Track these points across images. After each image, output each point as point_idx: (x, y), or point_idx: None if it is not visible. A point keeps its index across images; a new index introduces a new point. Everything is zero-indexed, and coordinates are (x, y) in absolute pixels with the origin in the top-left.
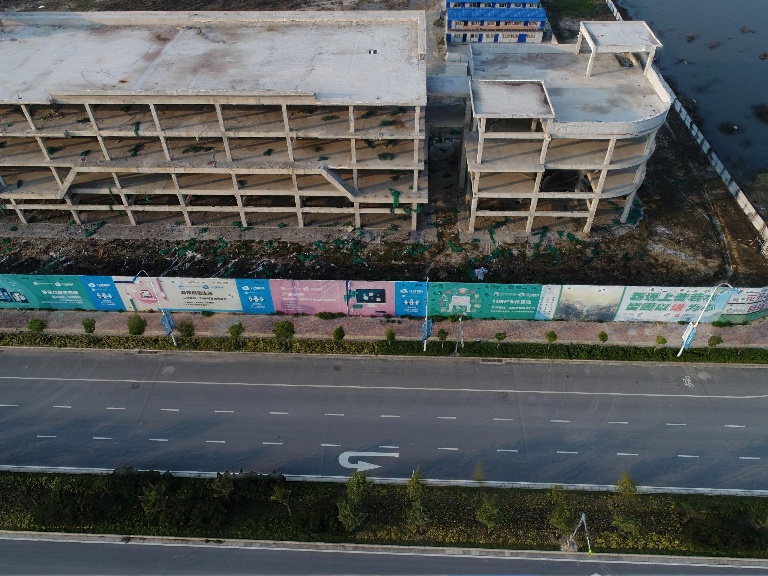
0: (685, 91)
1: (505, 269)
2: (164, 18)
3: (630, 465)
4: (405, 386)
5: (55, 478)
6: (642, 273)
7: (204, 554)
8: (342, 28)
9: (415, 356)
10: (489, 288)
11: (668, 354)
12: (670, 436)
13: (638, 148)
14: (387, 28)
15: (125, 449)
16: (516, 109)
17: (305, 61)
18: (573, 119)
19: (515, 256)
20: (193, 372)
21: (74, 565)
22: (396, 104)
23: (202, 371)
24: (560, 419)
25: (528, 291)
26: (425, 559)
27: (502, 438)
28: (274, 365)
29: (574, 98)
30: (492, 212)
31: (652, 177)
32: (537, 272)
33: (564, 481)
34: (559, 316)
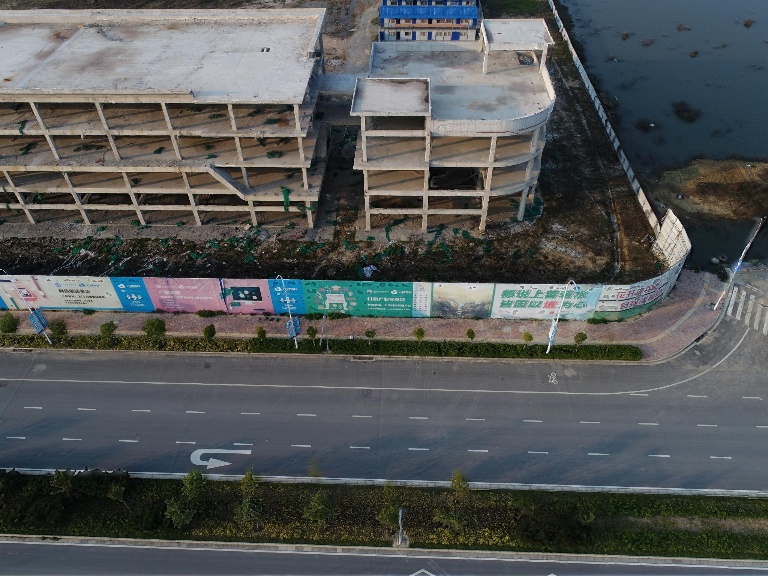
0: (609, 89)
1: (394, 267)
2: (66, 16)
3: (478, 461)
4: (271, 383)
5: None
6: (529, 270)
7: (38, 551)
8: (243, 26)
9: (287, 354)
10: (361, 286)
11: (537, 351)
12: (524, 433)
13: (526, 146)
14: (287, 26)
15: None
16: (395, 107)
17: (195, 59)
18: (457, 117)
19: (407, 254)
20: (64, 370)
21: None
22: (272, 102)
23: (73, 369)
24: (418, 416)
25: (400, 289)
26: (256, 555)
27: (357, 435)
28: (146, 363)
29: (464, 96)
30: (385, 210)
31: (559, 175)
32: (425, 270)
33: (410, 478)
34: (436, 313)
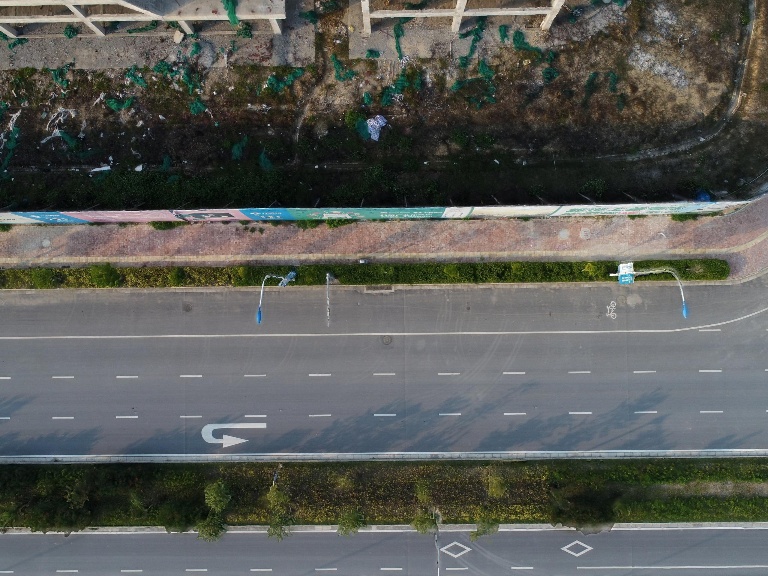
0: None
1: (411, 118)
2: None
3: (514, 427)
4: (271, 332)
5: None
6: (606, 119)
7: (82, 541)
8: None
9: None
10: (372, 211)
11: (599, 273)
12: (568, 388)
13: None
14: None
15: None
16: None
17: None
18: None
19: (429, 88)
20: (11, 322)
21: None
22: None
23: (22, 320)
24: (449, 371)
25: (426, 211)
26: (295, 536)
27: (381, 399)
28: (109, 307)
29: None
30: (395, 13)
31: None
32: (456, 123)
33: (441, 449)
34: (472, 217)
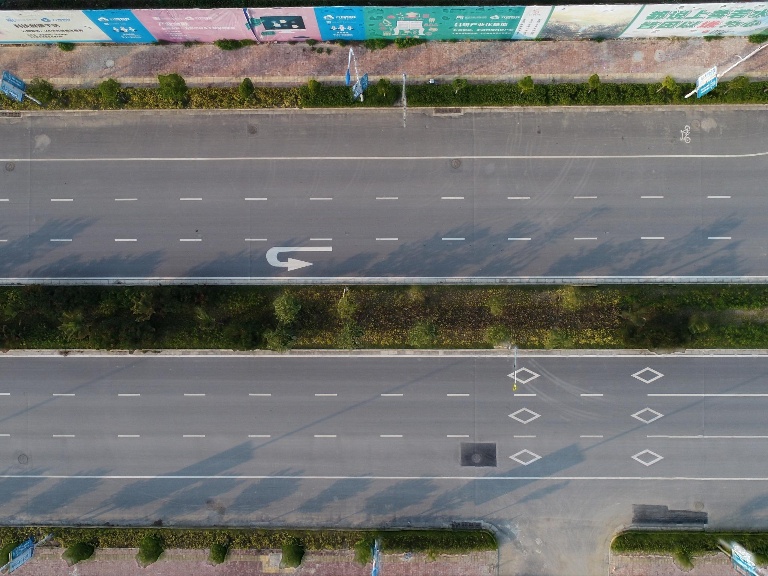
0: None
1: None
2: None
3: (585, 252)
4: (338, 155)
5: None
6: None
7: (145, 364)
8: None
9: (350, 108)
10: (449, 12)
11: (674, 95)
12: (640, 213)
13: None
14: None
15: (27, 253)
16: None
17: None
18: None
19: None
20: (74, 143)
21: (23, 379)
22: None
23: (85, 141)
24: (519, 195)
25: (504, 13)
26: (360, 360)
27: (449, 223)
28: (173, 128)
29: None
30: None
31: None
32: None
33: (510, 273)
34: (545, 35)
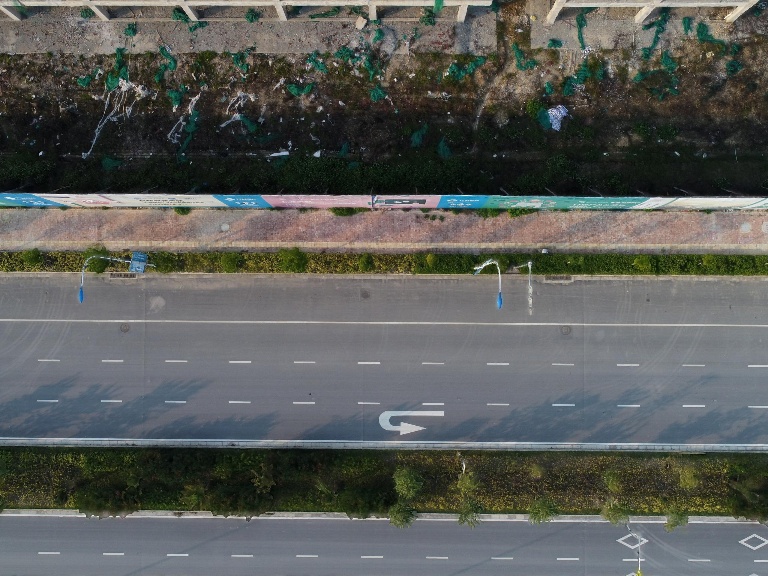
0: None
1: (593, 108)
2: None
3: (694, 420)
4: (450, 320)
5: (80, 455)
6: None
7: (258, 525)
8: None
9: (462, 274)
10: (573, 200)
11: None
12: (747, 382)
13: None
14: None
15: (142, 415)
16: None
17: None
18: None
19: (611, 78)
20: (189, 305)
21: (136, 539)
22: None
23: (199, 304)
24: (628, 363)
25: (626, 201)
26: None
27: (559, 389)
28: (287, 292)
29: None
30: (591, 3)
31: None
32: (639, 114)
33: (619, 440)
34: None
